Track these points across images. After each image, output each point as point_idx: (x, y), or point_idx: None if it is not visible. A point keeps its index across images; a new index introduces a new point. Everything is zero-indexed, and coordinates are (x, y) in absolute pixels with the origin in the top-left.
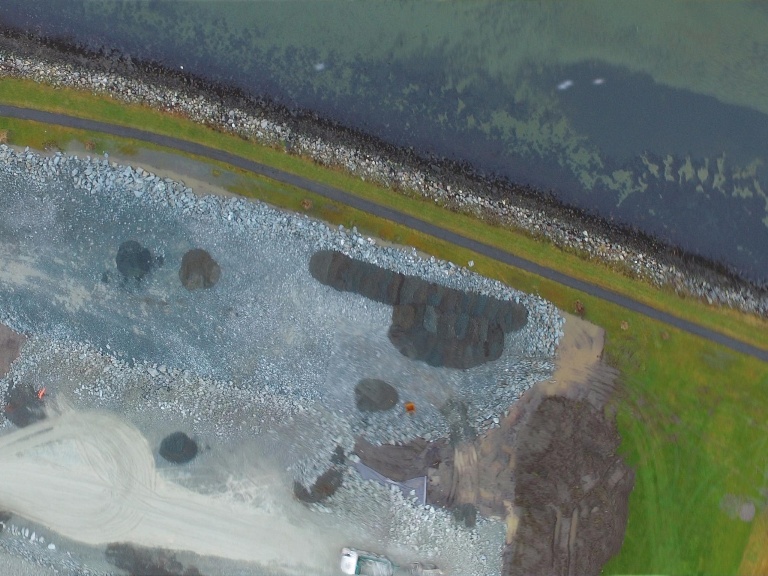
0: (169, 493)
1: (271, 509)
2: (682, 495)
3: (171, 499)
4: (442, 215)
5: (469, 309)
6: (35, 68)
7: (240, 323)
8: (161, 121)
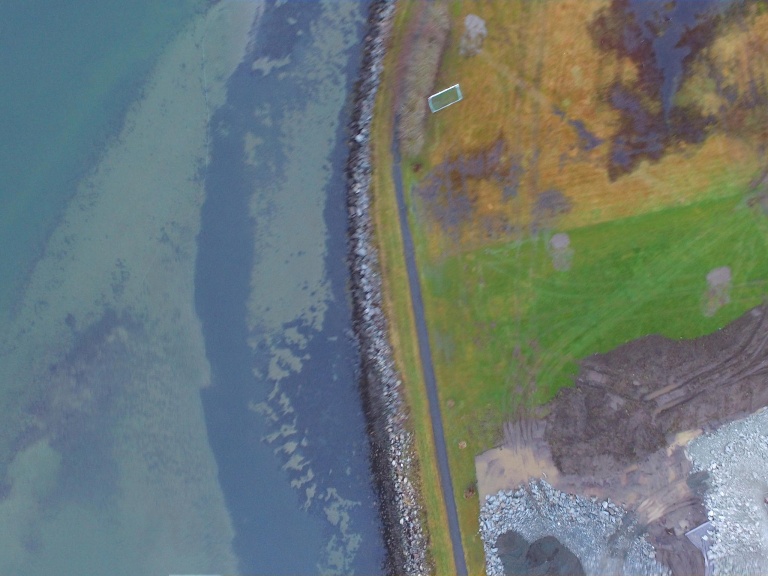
0: None
1: None
2: (579, 308)
3: None
4: None
5: None
6: None
7: None
8: None
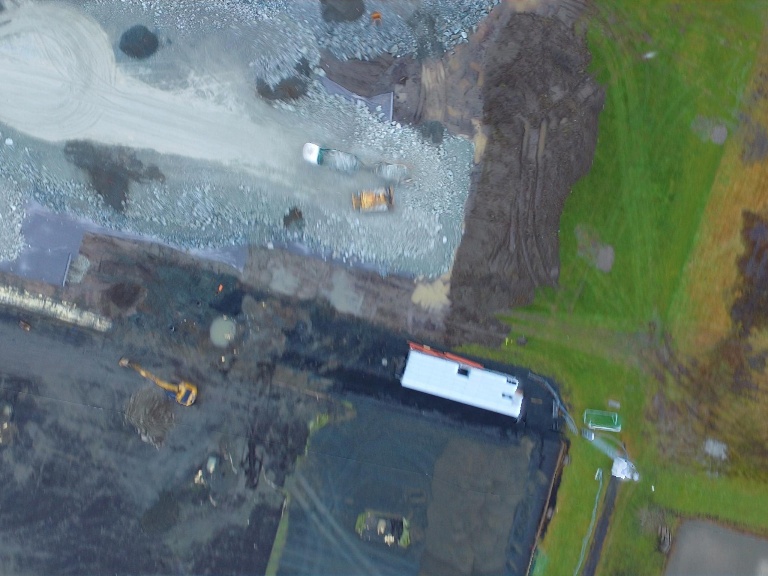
0: (129, 89)
1: (233, 107)
2: (653, 115)
3: (131, 95)
4: None
5: None
6: None
7: None
8: None
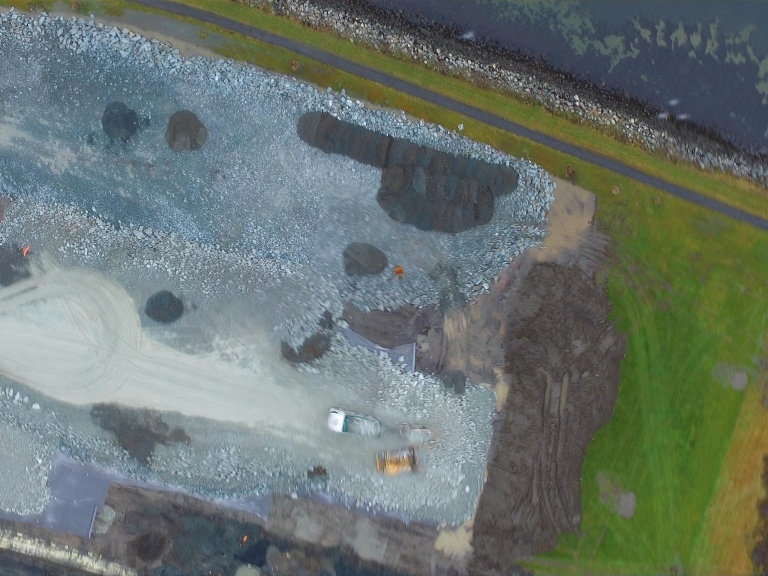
0: (155, 353)
1: (258, 369)
2: (674, 363)
3: (157, 359)
4: (431, 78)
5: (458, 170)
6: None
7: (227, 186)
8: None
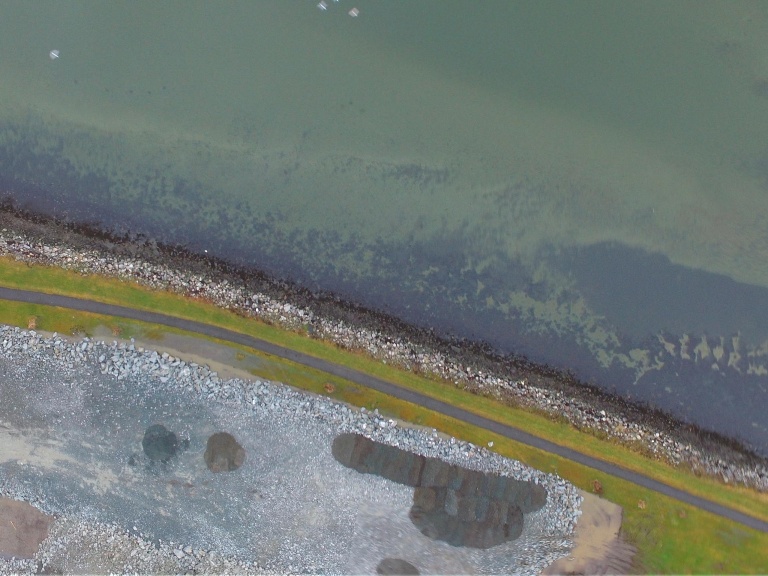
0: None
1: None
2: None
3: None
4: (462, 397)
5: (489, 492)
6: (63, 255)
7: (264, 505)
8: (186, 306)
